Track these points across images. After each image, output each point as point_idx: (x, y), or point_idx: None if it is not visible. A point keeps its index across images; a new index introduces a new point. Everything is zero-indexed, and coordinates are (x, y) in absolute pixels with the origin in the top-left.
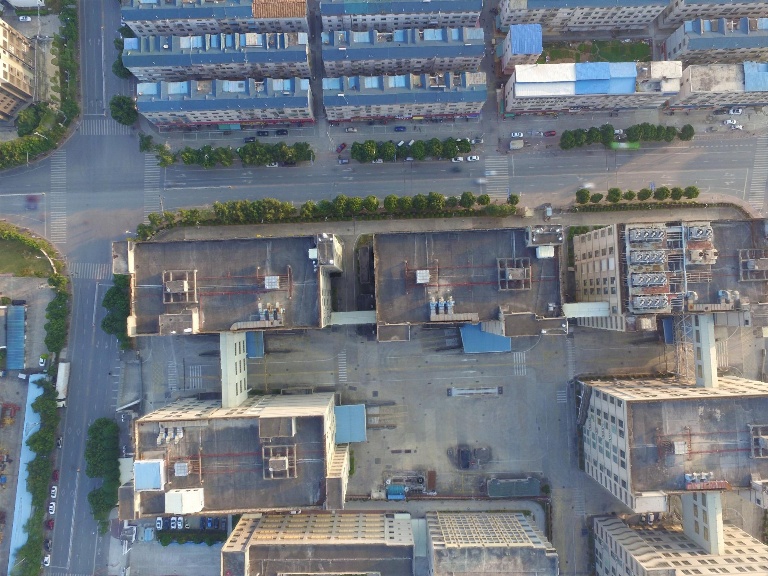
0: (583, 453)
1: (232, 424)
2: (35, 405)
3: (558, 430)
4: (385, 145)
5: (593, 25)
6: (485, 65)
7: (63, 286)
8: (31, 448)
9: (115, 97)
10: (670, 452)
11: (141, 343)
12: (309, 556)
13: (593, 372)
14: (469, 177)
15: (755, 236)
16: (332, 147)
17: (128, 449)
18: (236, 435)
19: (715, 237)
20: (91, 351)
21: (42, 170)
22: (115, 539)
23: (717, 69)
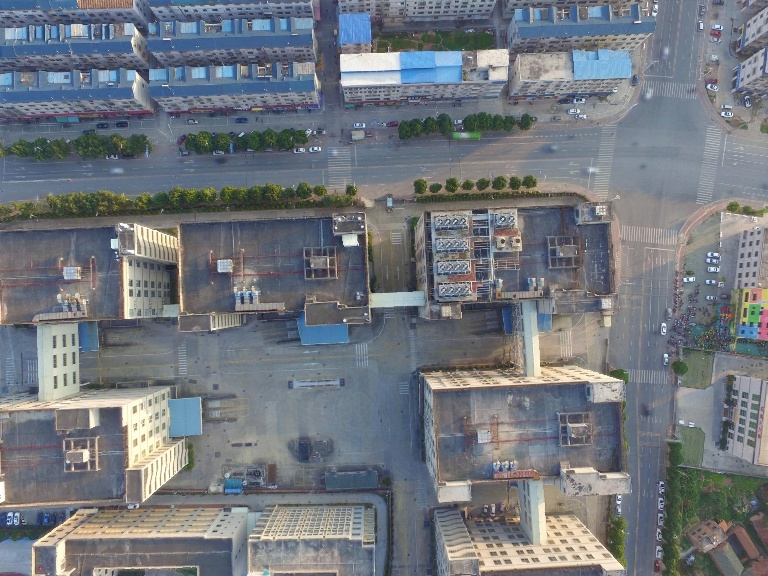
0: (424, 445)
1: (34, 417)
2: None
3: (400, 422)
4: (218, 136)
5: (434, 15)
6: (328, 56)
7: None
8: None
9: None
10: None
11: None
12: (127, 550)
13: (436, 363)
14: (311, 168)
15: (565, 223)
16: (173, 139)
17: None
18: (38, 428)
19: (525, 224)
20: None
21: None
22: None
23: (546, 57)
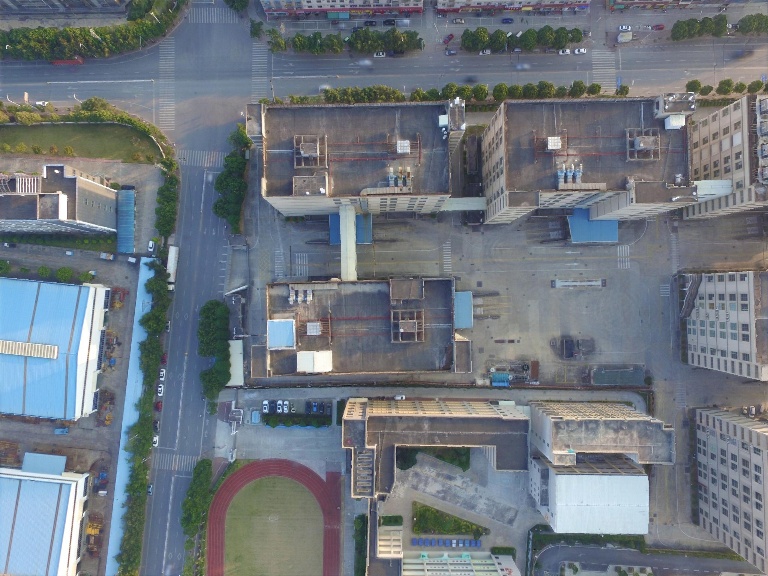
0: (686, 345)
1: (360, 289)
2: (149, 284)
3: (661, 323)
4: (498, 32)
5: None
6: None
7: (173, 171)
8: (145, 326)
9: None
10: None
11: (248, 230)
12: (426, 429)
13: (697, 266)
14: (576, 70)
15: None
16: (439, 38)
17: (238, 331)
18: (364, 300)
19: None
20: (199, 238)
21: (151, 57)
22: (222, 422)
23: None
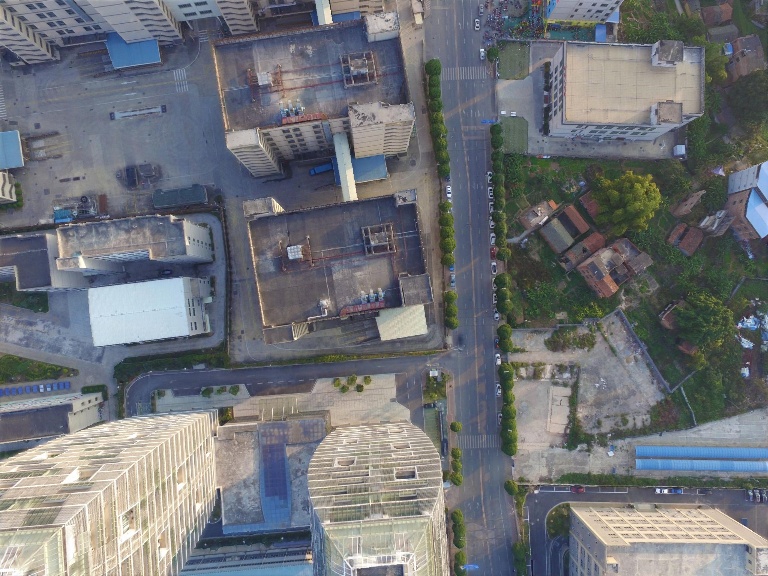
0: None
1: None
2: None
3: None
4: None
5: None
6: None
7: None
8: None
9: None
10: (264, 91)
11: None
12: None
13: None
14: None
15: None
16: None
17: None
18: None
19: None
20: None
21: None
22: None
23: None
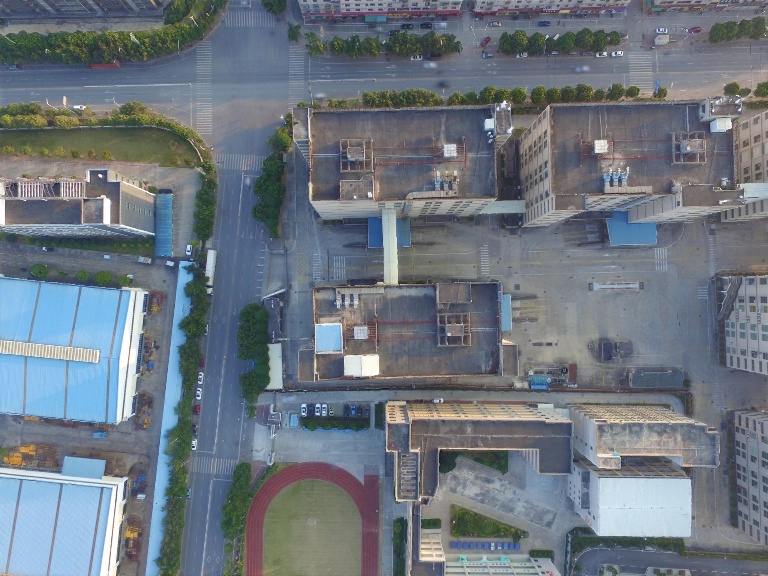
0: (724, 348)
1: (406, 293)
2: (188, 288)
3: (698, 326)
4: (536, 35)
5: None
6: None
7: (211, 175)
8: (185, 330)
9: None
10: None
11: (286, 233)
12: (469, 432)
13: (734, 269)
14: (613, 73)
15: None
16: (476, 41)
17: (277, 335)
18: (410, 303)
19: None
20: (236, 241)
21: (188, 61)
22: (260, 425)
23: None
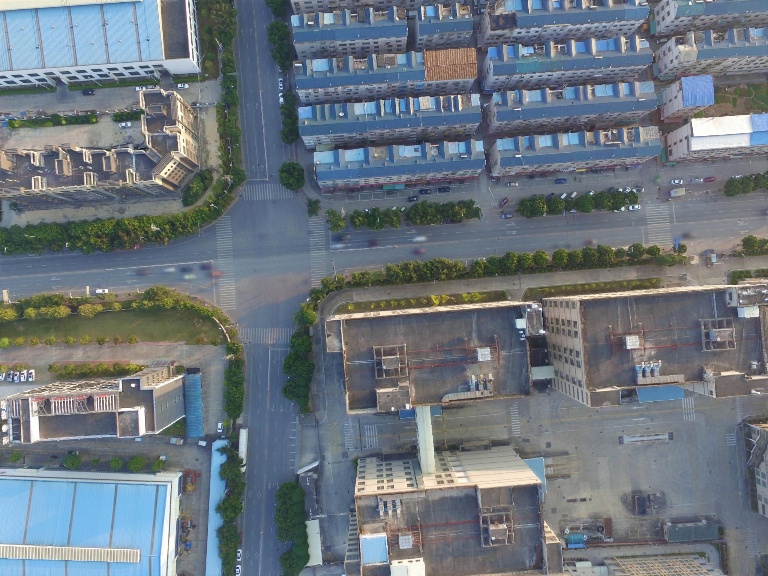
0: (755, 494)
1: (447, 494)
2: (224, 474)
3: (729, 472)
4: (556, 201)
5: (750, 69)
6: None
7: None
8: (223, 516)
9: (285, 164)
10: None
11: (316, 405)
12: None
13: (761, 414)
14: (631, 226)
15: None
16: (494, 202)
17: (314, 511)
18: (452, 504)
19: None
20: (267, 415)
21: (208, 237)
22: None
23: None
